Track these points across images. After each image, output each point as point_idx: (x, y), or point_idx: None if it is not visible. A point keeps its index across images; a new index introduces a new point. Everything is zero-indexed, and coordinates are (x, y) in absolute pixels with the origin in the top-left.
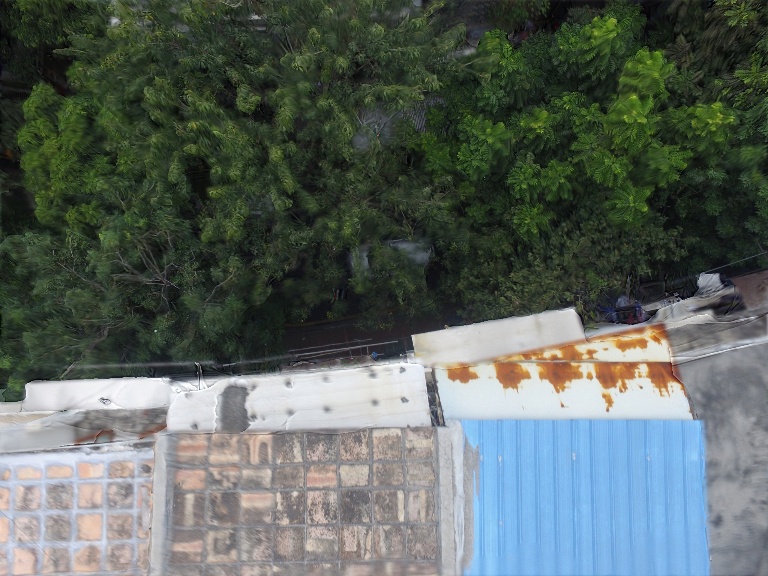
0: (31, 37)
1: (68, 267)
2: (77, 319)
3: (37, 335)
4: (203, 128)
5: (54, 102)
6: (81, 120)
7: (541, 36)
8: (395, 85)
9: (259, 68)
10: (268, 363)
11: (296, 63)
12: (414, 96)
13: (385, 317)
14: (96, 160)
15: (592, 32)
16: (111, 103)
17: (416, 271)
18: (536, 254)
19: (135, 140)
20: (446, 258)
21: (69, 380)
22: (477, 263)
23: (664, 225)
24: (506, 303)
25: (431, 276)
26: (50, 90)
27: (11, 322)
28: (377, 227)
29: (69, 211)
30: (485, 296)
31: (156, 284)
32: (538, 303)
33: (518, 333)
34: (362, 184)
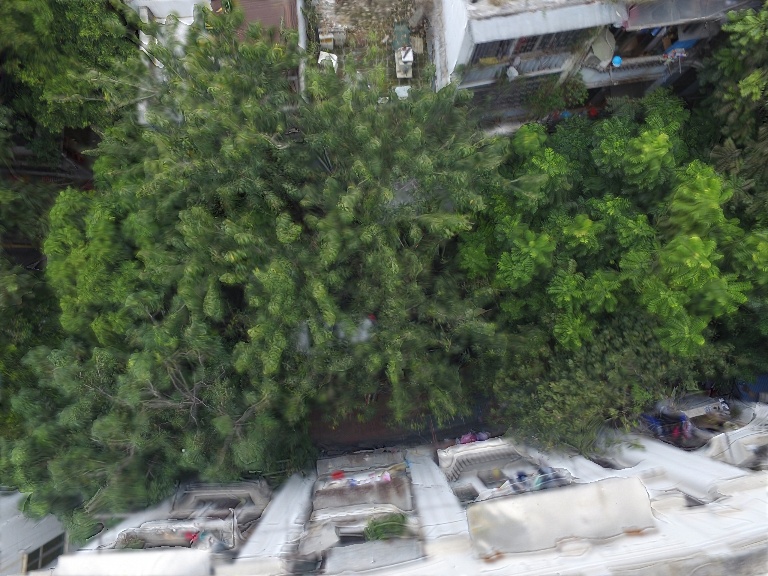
0: (57, 124)
1: (94, 386)
2: (102, 438)
3: (62, 462)
4: (240, 258)
5: (82, 208)
6: (109, 227)
7: (577, 121)
8: (441, 213)
9: (301, 201)
10: (294, 461)
11: (342, 204)
12: (461, 226)
13: (416, 417)
14: (124, 266)
15: (643, 148)
16: (142, 217)
17: (451, 376)
18: (577, 362)
19: (168, 264)
20: (480, 357)
21: (101, 552)
22: (513, 364)
23: (715, 342)
24: (546, 414)
25: (463, 372)
26: (78, 196)
27: (34, 440)
28: (415, 342)
29: (95, 320)
30: (521, 398)
31: (185, 403)
32: (581, 418)
33: (579, 504)
34: (402, 307)
